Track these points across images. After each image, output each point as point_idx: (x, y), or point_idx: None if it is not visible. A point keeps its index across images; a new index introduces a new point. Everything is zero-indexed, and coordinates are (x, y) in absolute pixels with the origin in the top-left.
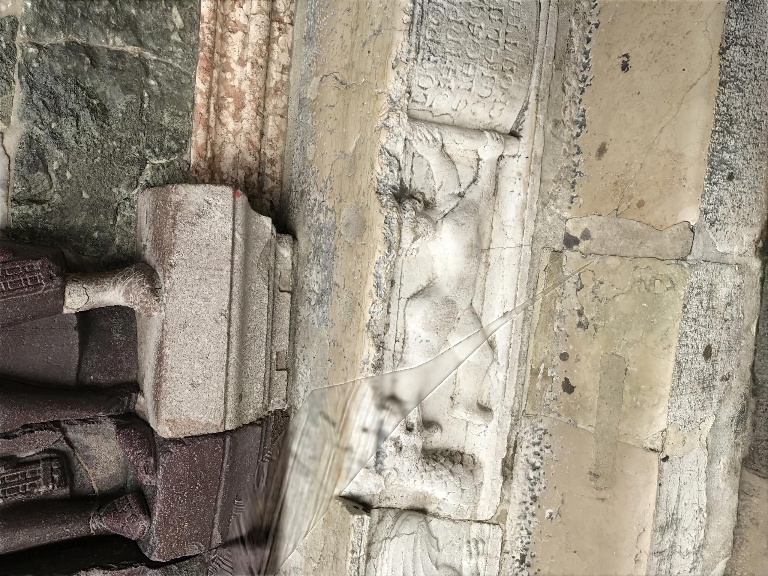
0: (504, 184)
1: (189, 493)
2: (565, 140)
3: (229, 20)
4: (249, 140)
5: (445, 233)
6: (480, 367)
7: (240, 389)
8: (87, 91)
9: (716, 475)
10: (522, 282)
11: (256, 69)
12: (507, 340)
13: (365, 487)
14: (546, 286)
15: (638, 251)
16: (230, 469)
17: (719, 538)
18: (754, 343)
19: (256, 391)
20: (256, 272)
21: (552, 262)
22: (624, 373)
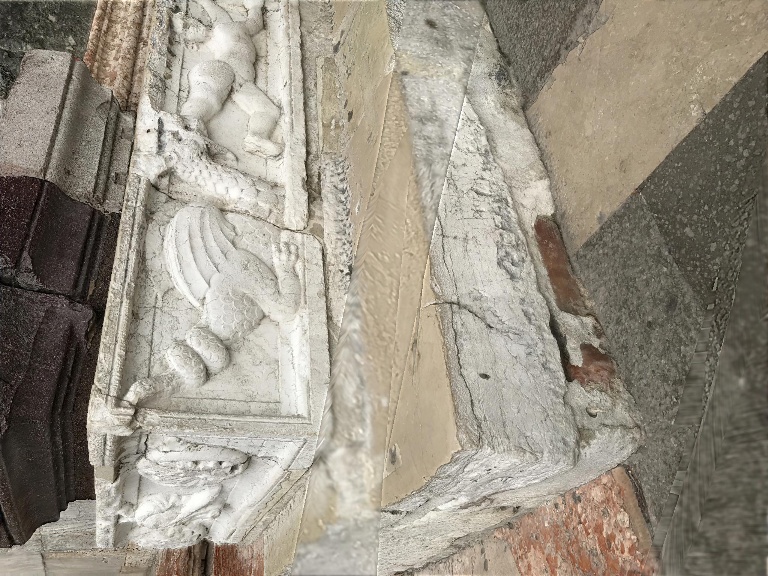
0: (272, 24)
1: (2, 213)
2: (320, 5)
3: (110, 45)
4: (118, 92)
5: (215, 31)
6: (266, 114)
7: (68, 167)
8: (3, 67)
9: (486, 106)
10: (295, 65)
11: (125, 60)
12: (288, 96)
13: (151, 175)
14: (324, 76)
15: (360, 0)
16: (47, 208)
17: (519, 158)
18: (494, 37)
19: (87, 180)
20: (94, 112)
21: (326, 63)
22: (367, 58)
